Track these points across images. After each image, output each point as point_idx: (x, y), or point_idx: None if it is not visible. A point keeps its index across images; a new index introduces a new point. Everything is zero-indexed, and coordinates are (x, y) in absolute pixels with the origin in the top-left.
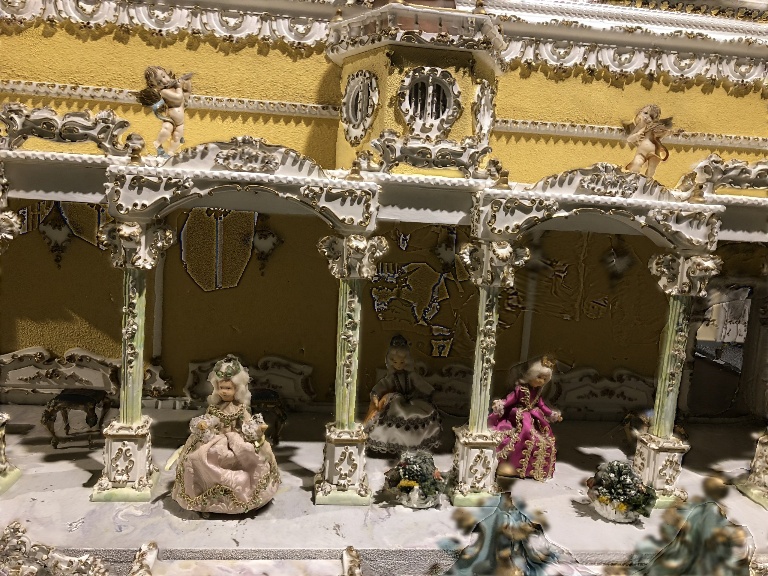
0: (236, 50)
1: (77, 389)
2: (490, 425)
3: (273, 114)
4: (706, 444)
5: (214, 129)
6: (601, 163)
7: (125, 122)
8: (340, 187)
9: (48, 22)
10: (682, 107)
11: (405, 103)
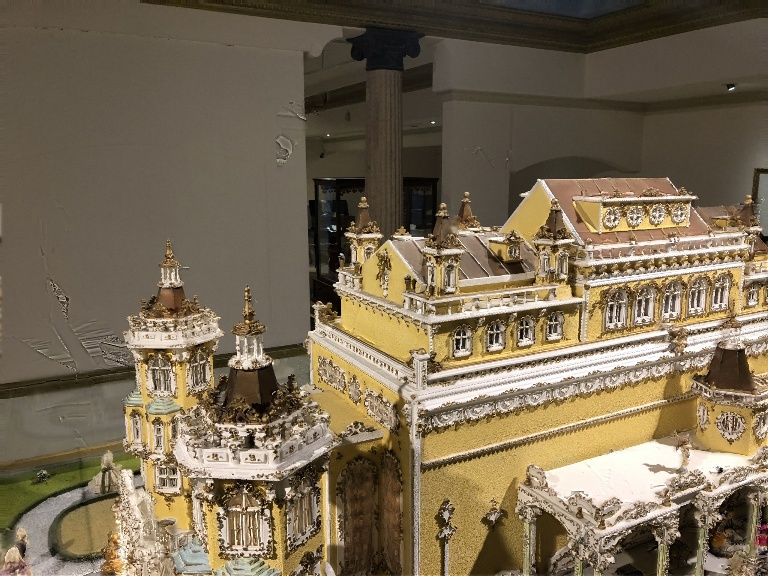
0: (637, 385)
1: (630, 568)
2: (767, 533)
3: (649, 409)
4: None
5: (629, 423)
6: None
7: (702, 473)
8: (765, 477)
9: (576, 396)
10: None
11: None
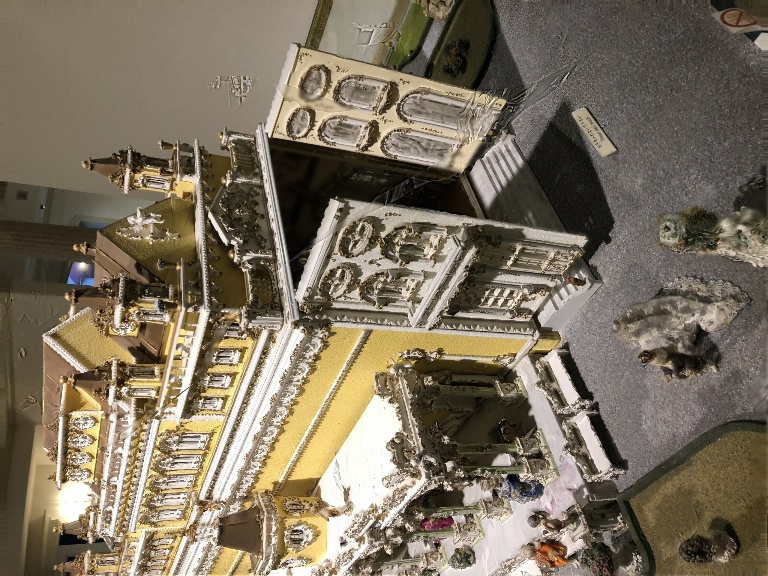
0: None
1: None
2: None
3: None
4: (487, 439)
5: None
6: (336, 562)
7: None
8: None
9: None
10: (303, 410)
11: (291, 567)
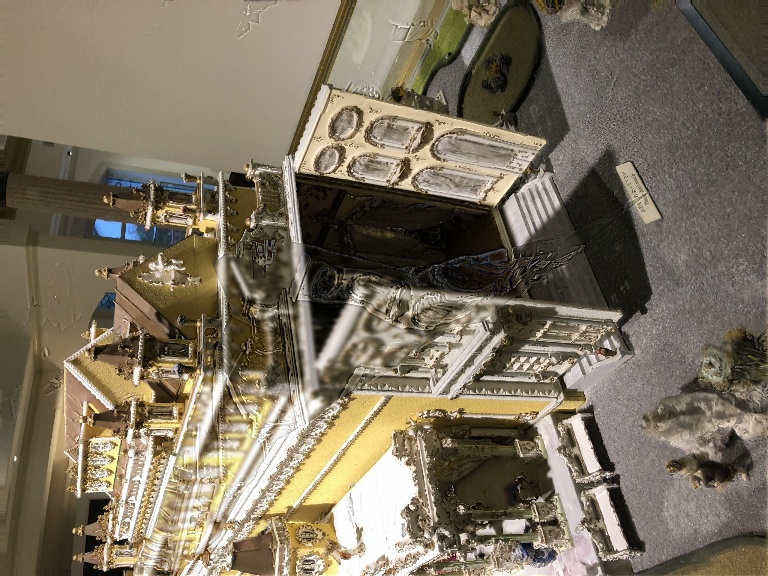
0: None
1: None
2: None
3: None
4: (503, 488)
5: None
6: None
7: None
8: None
9: None
10: None
11: None
